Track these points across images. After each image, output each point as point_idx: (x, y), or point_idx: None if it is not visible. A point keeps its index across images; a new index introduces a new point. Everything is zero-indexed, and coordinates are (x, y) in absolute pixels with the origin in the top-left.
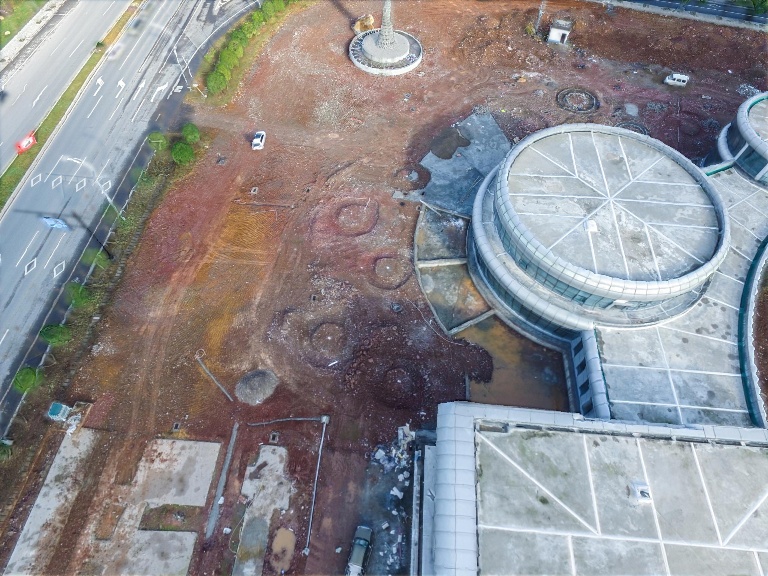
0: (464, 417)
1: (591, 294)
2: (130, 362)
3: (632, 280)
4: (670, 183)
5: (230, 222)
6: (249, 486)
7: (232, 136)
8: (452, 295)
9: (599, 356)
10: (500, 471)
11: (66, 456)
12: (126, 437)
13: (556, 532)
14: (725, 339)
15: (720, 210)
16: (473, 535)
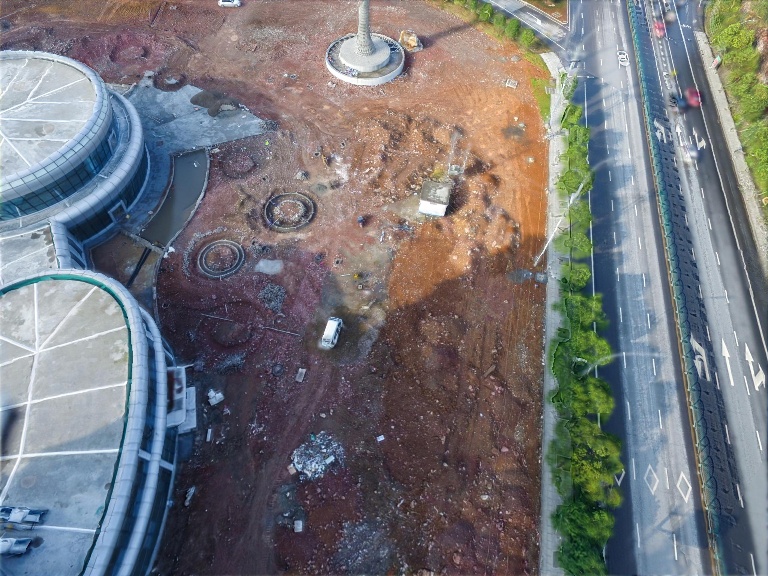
0: None
1: None
2: None
3: None
4: None
5: (144, 3)
6: None
7: None
8: None
9: None
10: None
11: None
12: None
13: None
14: None
15: None
16: None
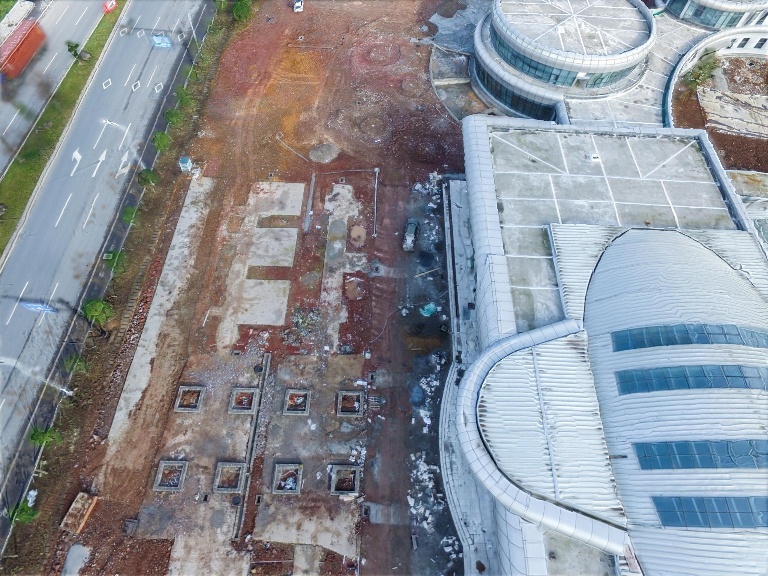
0: (481, 121)
1: (561, 70)
2: (228, 141)
3: (589, 55)
4: (616, 7)
5: (286, 58)
6: (329, 205)
7: (276, 4)
8: (461, 101)
9: (567, 114)
10: (505, 149)
11: (195, 191)
12: (236, 181)
13: (541, 173)
14: (653, 106)
15: (650, 20)
16: (491, 172)
